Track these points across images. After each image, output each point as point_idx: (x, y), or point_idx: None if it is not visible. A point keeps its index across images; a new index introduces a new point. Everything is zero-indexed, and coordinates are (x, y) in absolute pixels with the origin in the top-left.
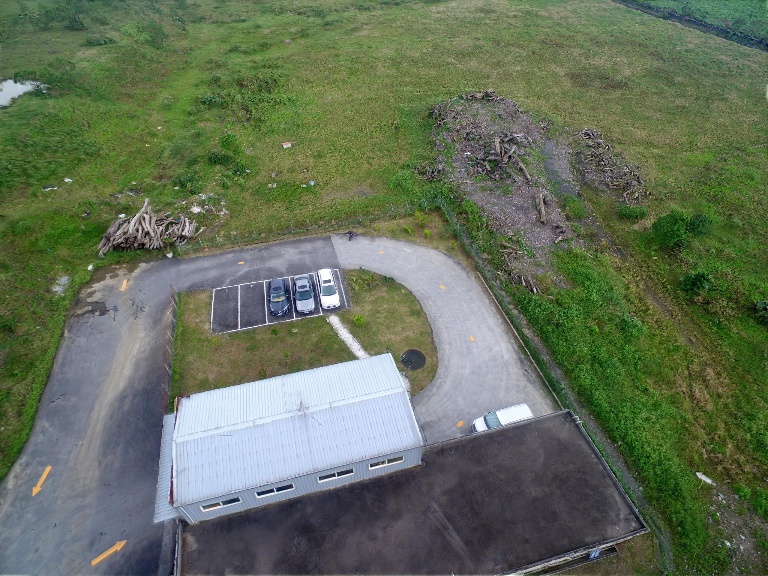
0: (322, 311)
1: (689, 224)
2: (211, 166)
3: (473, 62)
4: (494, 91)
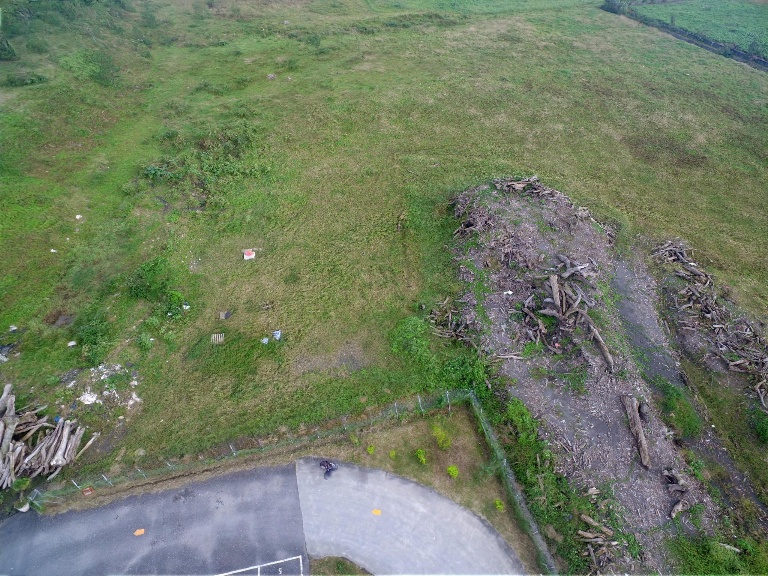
0: None
1: None
2: (130, 302)
3: (501, 116)
4: (539, 179)
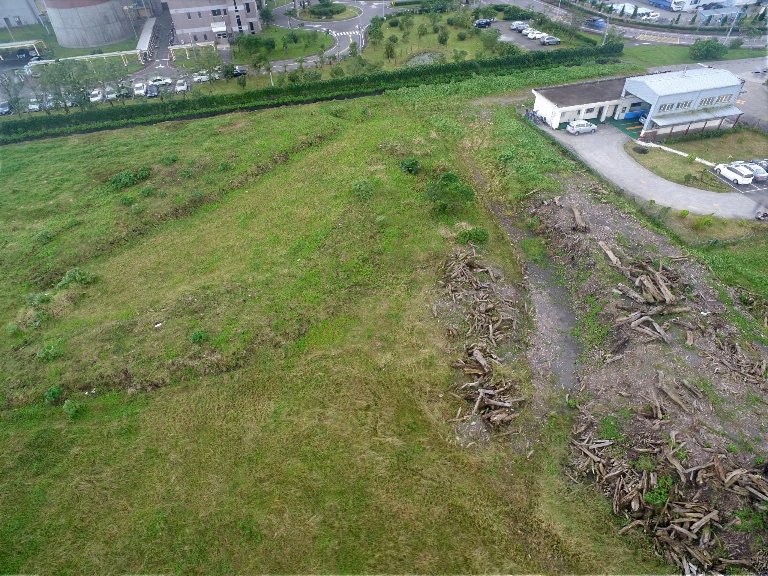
0: None
1: None
2: None
3: None
4: None
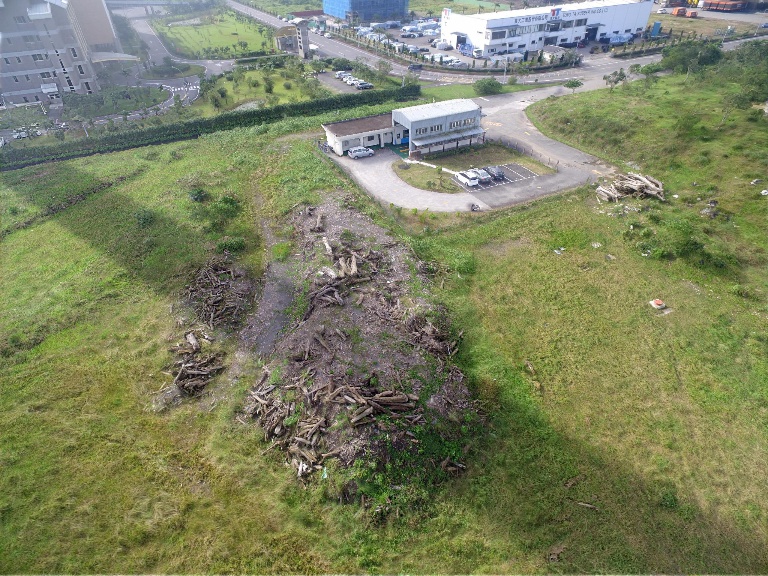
0: None
1: None
2: None
3: None
4: None
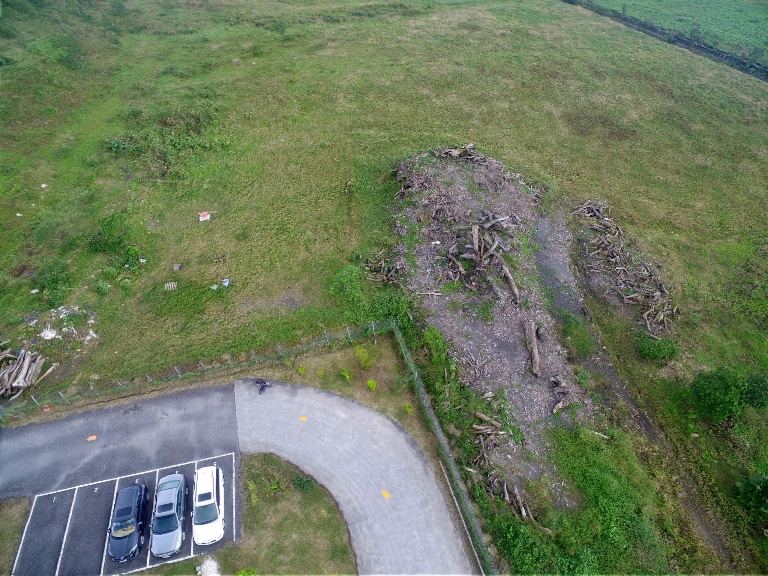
0: (194, 549)
1: (745, 390)
2: (90, 256)
3: (452, 96)
4: (474, 147)
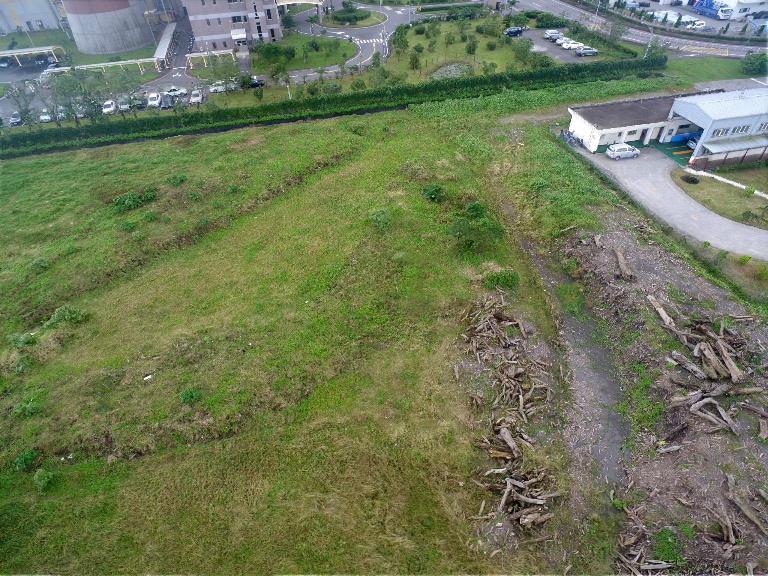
0: None
1: None
2: None
3: None
4: None
